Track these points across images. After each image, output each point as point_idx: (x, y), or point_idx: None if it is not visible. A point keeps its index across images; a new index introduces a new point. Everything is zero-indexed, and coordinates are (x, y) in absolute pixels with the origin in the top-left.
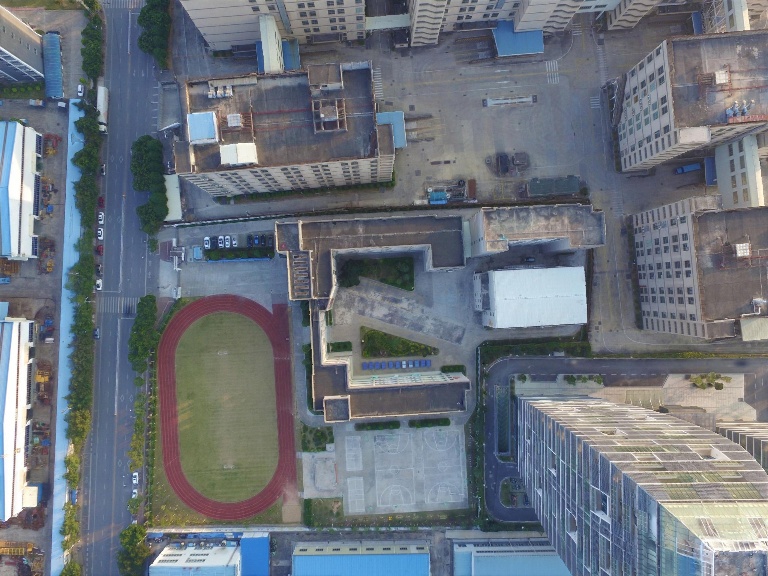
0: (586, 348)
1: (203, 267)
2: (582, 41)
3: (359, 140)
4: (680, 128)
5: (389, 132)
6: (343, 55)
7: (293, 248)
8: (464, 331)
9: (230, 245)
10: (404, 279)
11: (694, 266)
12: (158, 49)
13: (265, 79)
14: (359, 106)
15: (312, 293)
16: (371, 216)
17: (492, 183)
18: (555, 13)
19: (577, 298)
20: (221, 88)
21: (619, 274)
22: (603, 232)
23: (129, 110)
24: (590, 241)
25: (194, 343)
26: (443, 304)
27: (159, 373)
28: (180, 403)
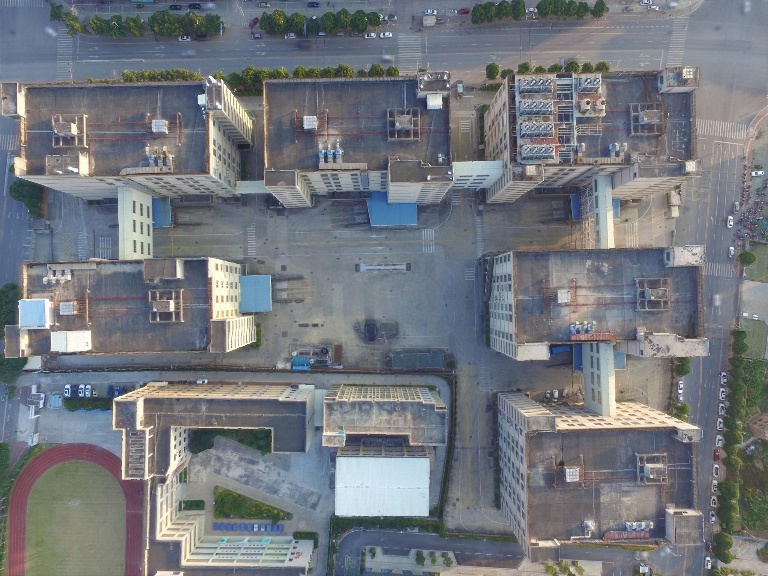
0: (439, 527)
1: (62, 414)
2: (461, 211)
3: (195, 331)
4: (518, 345)
5: (223, 329)
6: (218, 210)
7: (131, 426)
8: (320, 497)
9: (90, 394)
10: (259, 444)
11: (525, 484)
12: (28, 199)
13: (106, 264)
14: (198, 297)
15: (146, 473)
16: (234, 374)
17: (359, 349)
18: (421, 196)
19: (419, 491)
20: (59, 272)
21: (481, 451)
22: (445, 431)
23: (1, 251)
24: (432, 439)
25: (47, 490)
26: (300, 469)
27: (10, 518)
28: (29, 550)
